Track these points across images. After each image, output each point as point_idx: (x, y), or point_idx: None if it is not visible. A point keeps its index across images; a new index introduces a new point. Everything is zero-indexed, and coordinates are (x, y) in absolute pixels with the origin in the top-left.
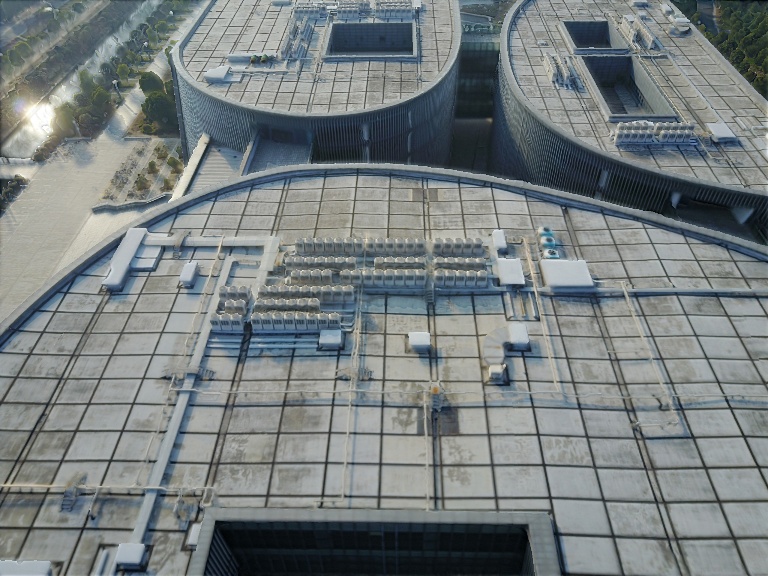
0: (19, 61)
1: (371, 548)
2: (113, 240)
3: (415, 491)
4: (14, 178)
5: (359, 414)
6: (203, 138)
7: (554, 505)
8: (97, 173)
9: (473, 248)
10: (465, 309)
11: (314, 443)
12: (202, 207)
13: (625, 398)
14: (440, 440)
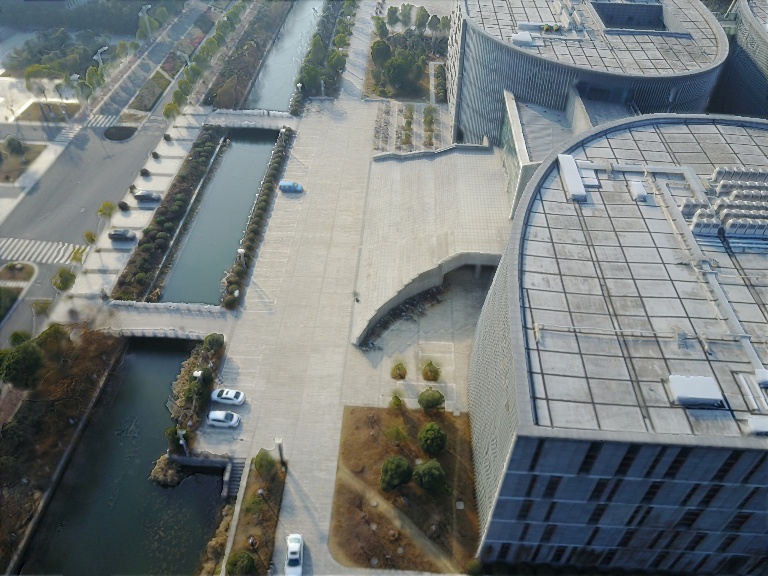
0: (232, 27)
1: None
2: (552, 162)
3: None
4: (283, 128)
5: None
6: (508, 95)
7: None
8: (356, 128)
9: None
10: None
11: None
12: (600, 142)
13: None
14: None
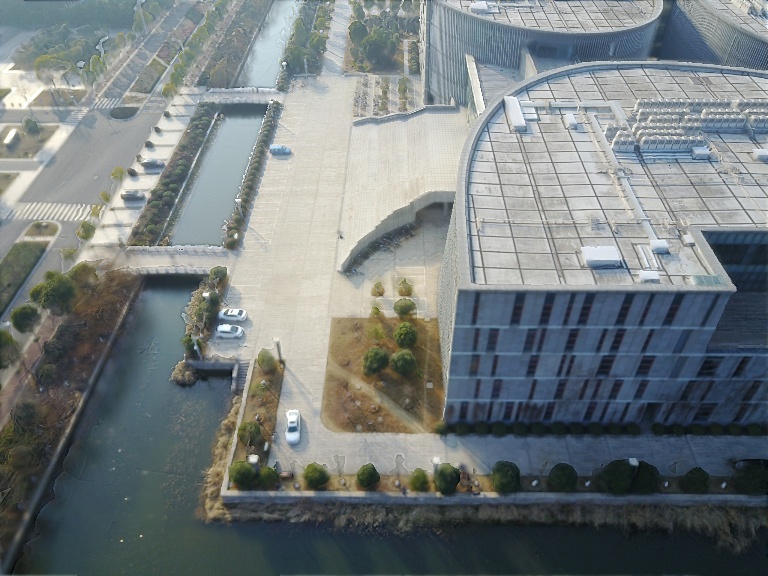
0: (220, 17)
1: None
2: (498, 103)
3: None
4: None
5: (747, 189)
6: (469, 58)
7: None
8: (337, 99)
9: (765, 106)
10: None
11: (728, 201)
12: (542, 86)
13: None
14: None
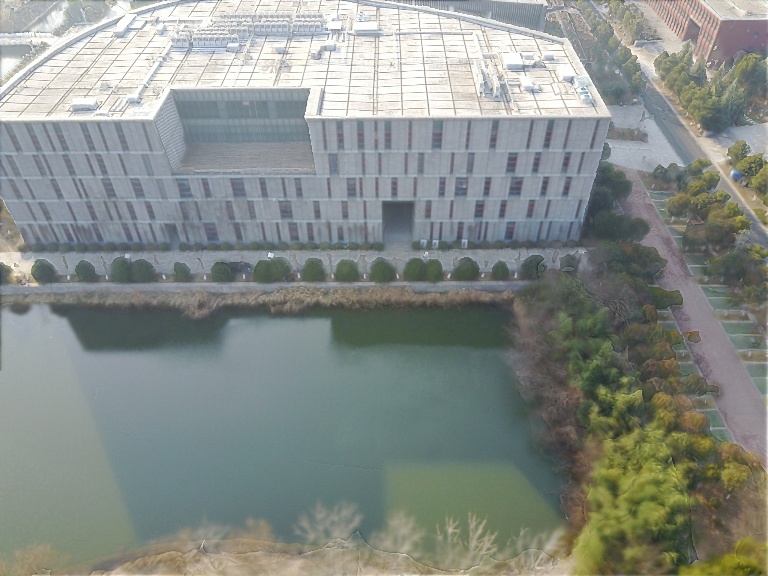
0: None
1: (245, 116)
2: (118, 18)
3: (264, 85)
4: (41, 43)
5: (243, 68)
6: None
7: (326, 87)
8: None
9: None
10: (307, 39)
11: (219, 75)
12: (169, 8)
13: (376, 63)
14: (280, 74)
